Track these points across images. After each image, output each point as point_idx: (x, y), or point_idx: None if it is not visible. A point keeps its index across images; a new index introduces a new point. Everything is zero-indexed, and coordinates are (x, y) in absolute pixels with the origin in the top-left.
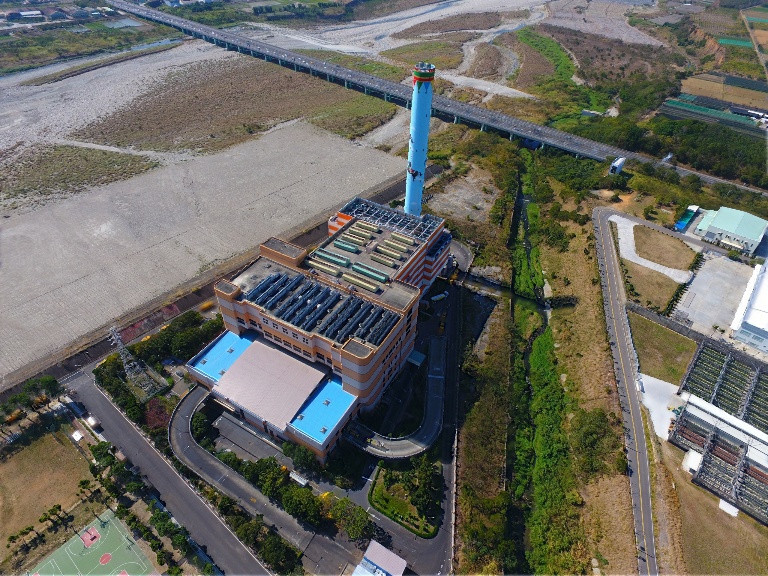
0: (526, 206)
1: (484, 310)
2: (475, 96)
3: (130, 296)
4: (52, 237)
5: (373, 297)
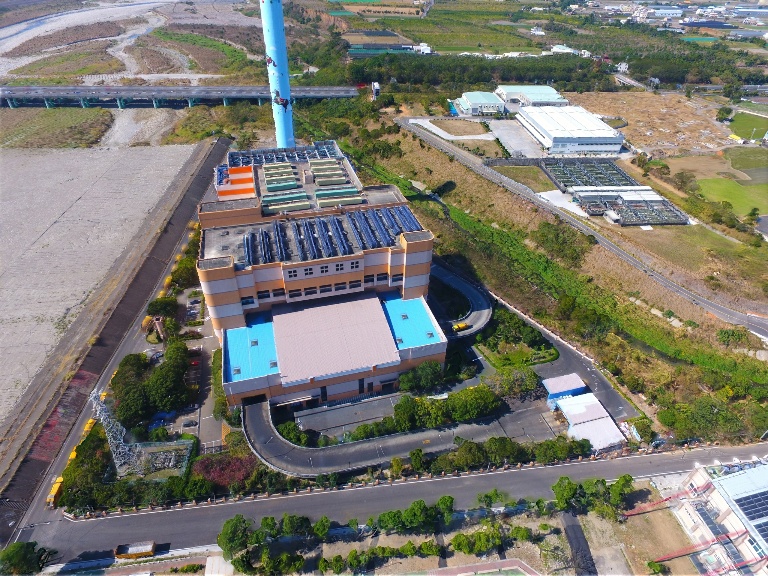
0: None
1: None
2: (181, 84)
3: None
4: None
5: None
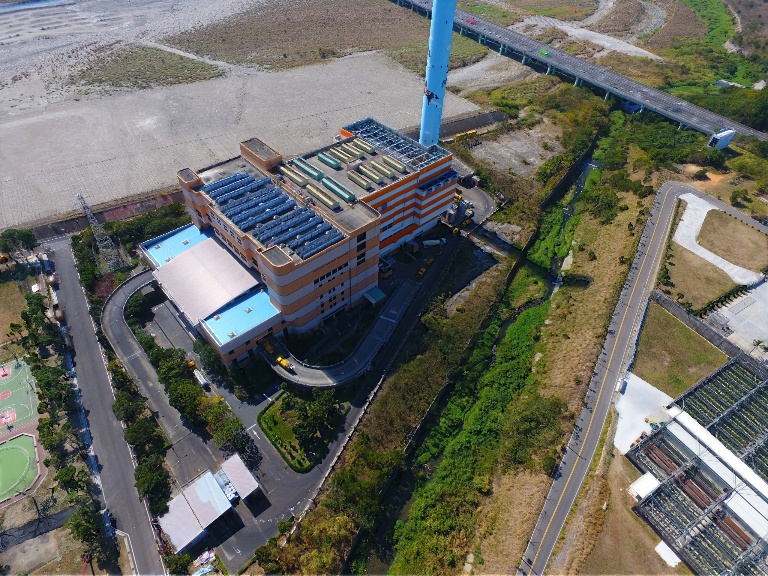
0: (589, 171)
1: (479, 266)
2: (587, 50)
3: (140, 183)
4: (103, 122)
5: (327, 213)
